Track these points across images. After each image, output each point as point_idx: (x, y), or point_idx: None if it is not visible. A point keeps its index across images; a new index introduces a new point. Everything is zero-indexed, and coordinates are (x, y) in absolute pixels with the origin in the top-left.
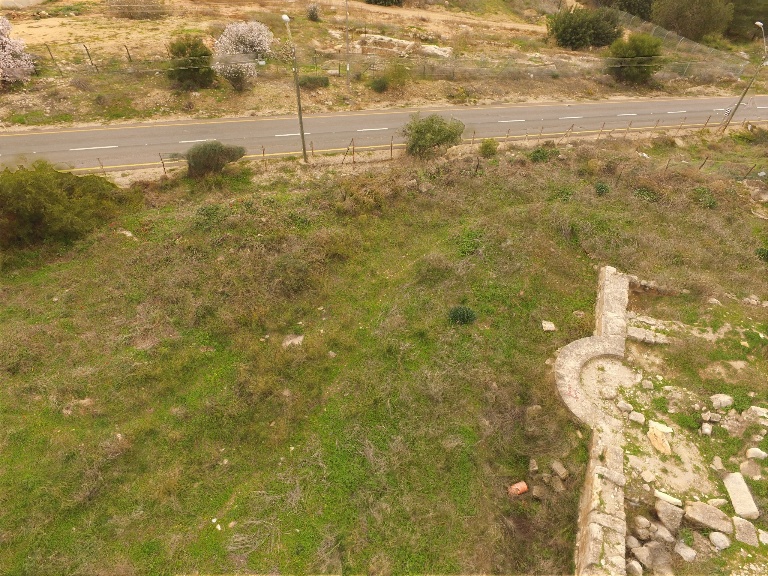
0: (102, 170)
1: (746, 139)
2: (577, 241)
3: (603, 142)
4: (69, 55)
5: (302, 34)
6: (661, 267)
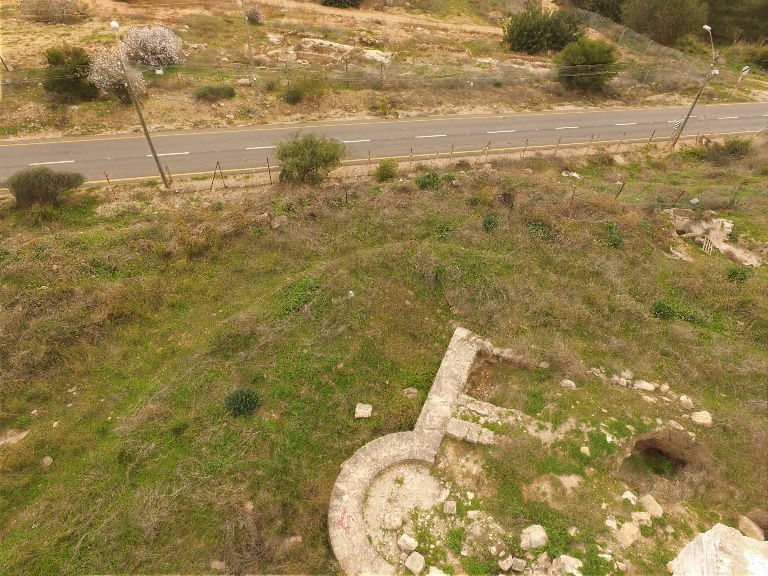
0: None
1: (697, 155)
2: (441, 291)
3: (528, 161)
4: None
5: (235, 39)
6: (527, 329)
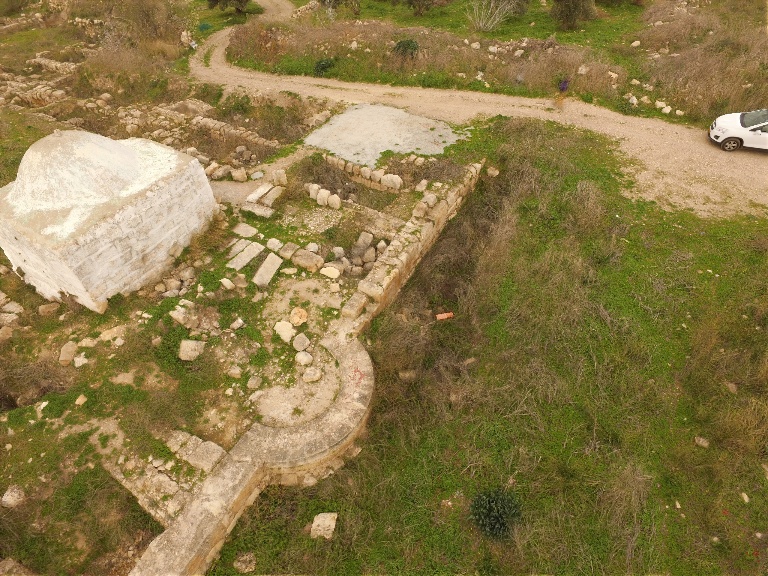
0: None
1: None
2: None
3: None
4: None
5: None
6: None
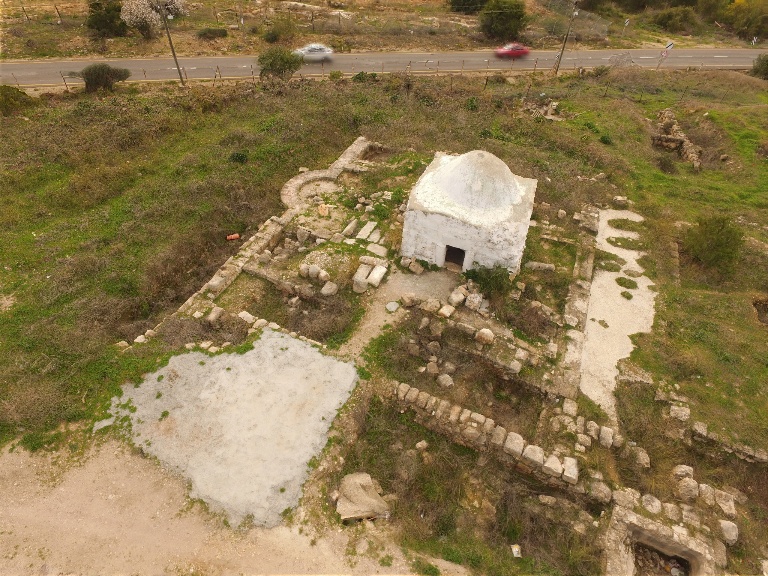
0: (16, 83)
1: None
2: (357, 128)
3: None
4: (11, 11)
5: None
6: None
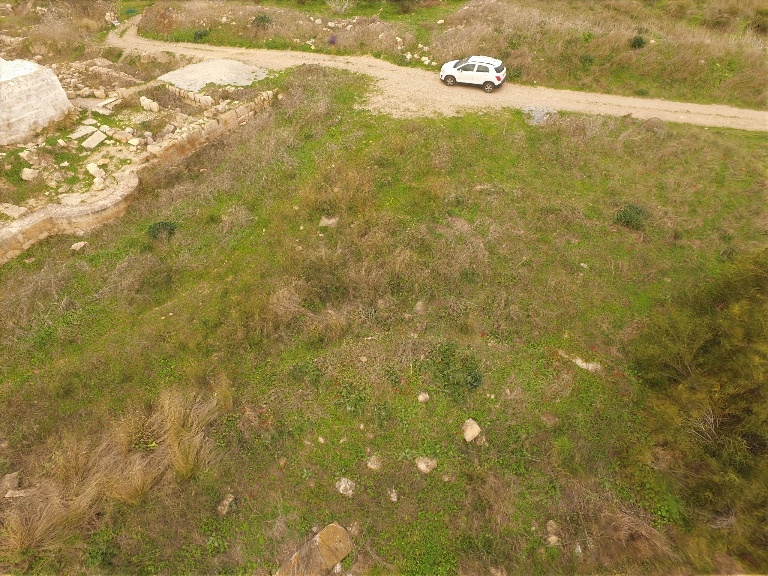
0: None
1: None
2: None
3: None
4: None
5: None
6: None
